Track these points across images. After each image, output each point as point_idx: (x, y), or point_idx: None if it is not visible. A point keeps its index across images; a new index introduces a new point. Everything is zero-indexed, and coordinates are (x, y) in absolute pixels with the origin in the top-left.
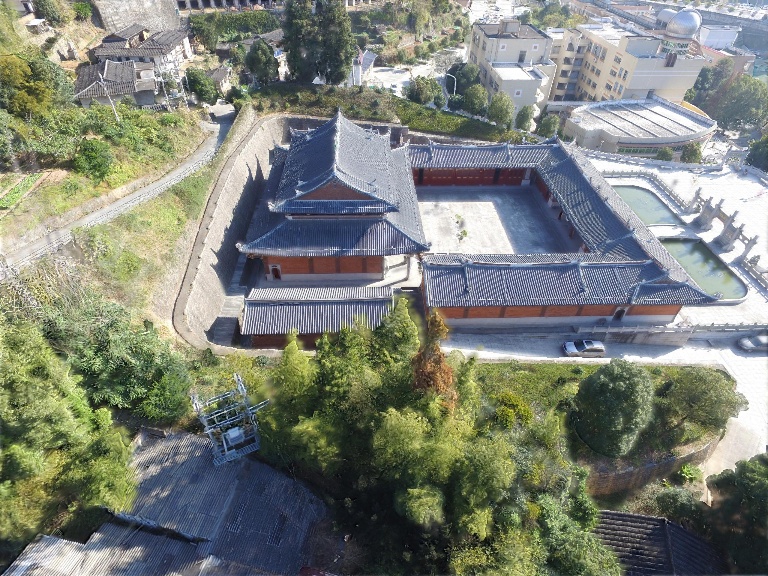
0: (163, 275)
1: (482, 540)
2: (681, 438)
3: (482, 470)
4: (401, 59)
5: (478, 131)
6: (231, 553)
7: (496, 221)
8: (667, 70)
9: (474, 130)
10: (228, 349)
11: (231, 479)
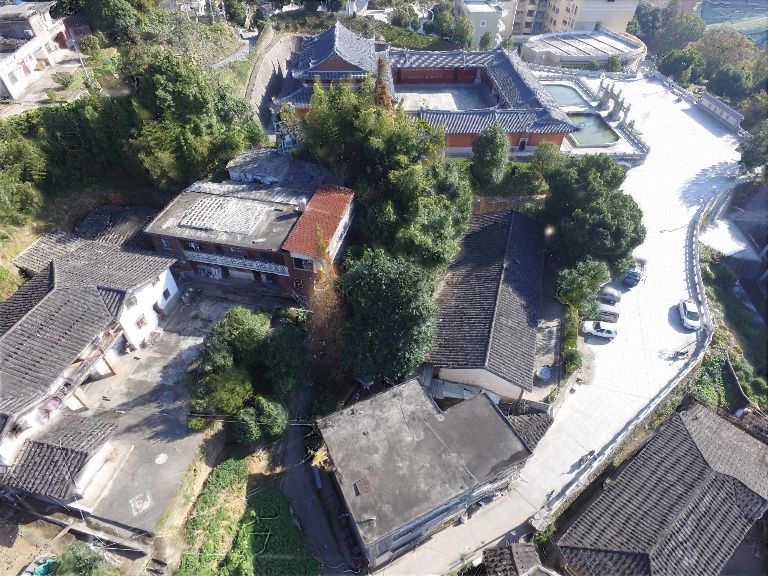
0: None
1: (402, 162)
2: (538, 189)
3: (402, 133)
4: (390, 2)
5: (445, 47)
6: (289, 186)
7: (452, 104)
8: (610, 5)
9: (442, 46)
10: None
11: (287, 160)
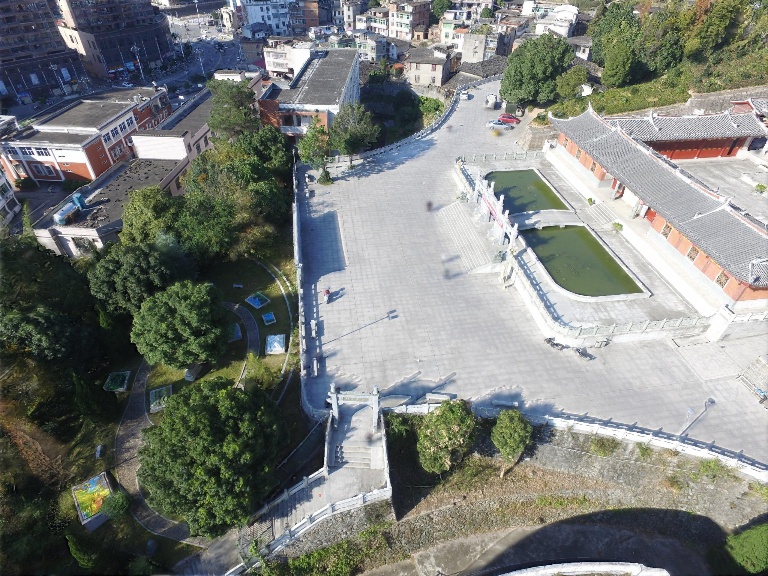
0: None
1: None
2: None
3: None
4: None
5: None
6: None
7: None
8: None
9: None
10: None
11: None
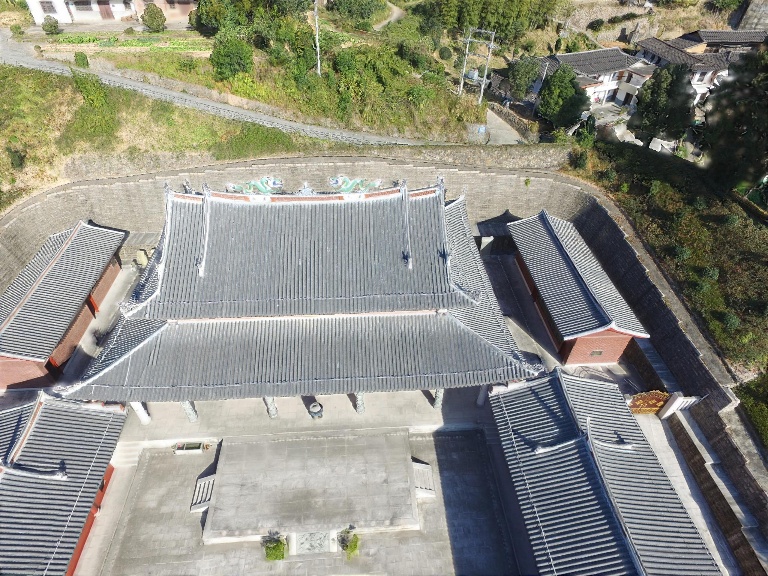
0: (109, 156)
1: None
2: None
3: None
4: None
5: None
6: None
7: None
8: None
9: None
10: (7, 221)
11: None
